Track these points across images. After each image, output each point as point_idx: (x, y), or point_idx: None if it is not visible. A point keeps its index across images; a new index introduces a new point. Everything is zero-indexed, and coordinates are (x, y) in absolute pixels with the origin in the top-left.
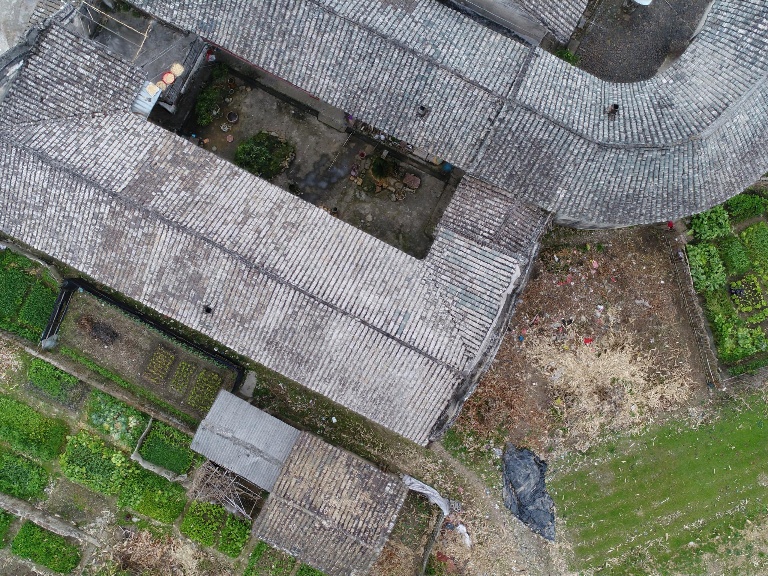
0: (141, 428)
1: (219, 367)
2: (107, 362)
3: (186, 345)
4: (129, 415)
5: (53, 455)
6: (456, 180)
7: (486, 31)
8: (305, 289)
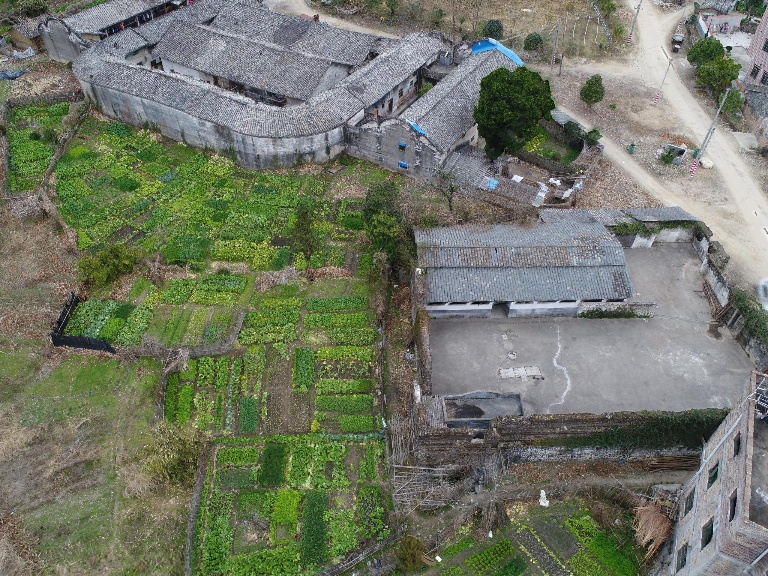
0: None
1: None
2: None
3: None
4: None
5: None
6: None
7: None
8: (98, 6)
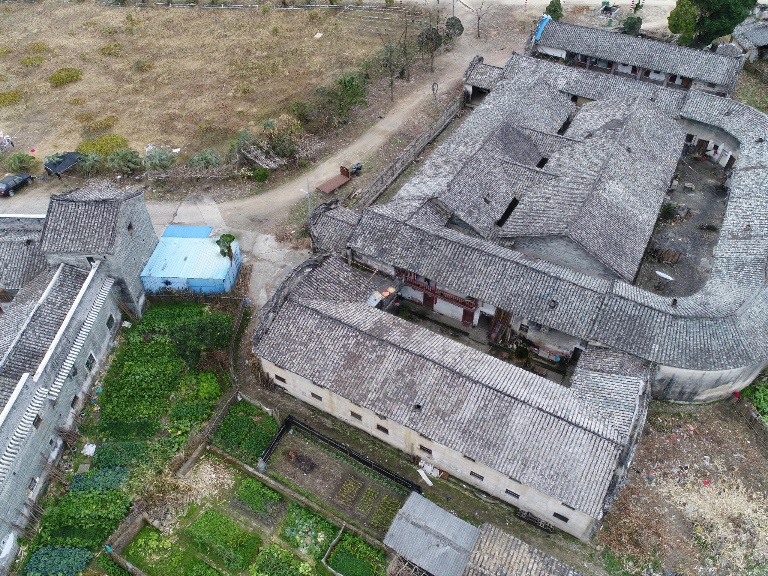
0: (329, 542)
1: (399, 493)
2: (304, 487)
3: (373, 474)
4: (319, 531)
5: (245, 564)
6: (571, 373)
7: (582, 274)
8: (493, 387)
